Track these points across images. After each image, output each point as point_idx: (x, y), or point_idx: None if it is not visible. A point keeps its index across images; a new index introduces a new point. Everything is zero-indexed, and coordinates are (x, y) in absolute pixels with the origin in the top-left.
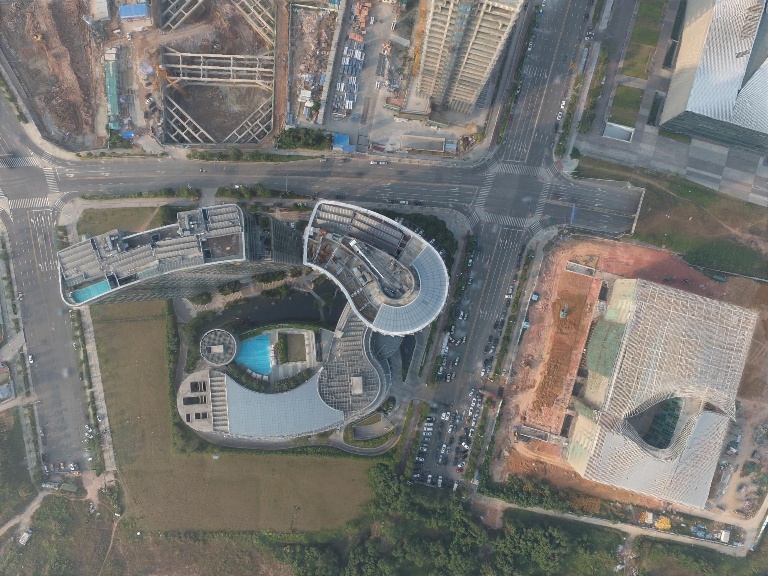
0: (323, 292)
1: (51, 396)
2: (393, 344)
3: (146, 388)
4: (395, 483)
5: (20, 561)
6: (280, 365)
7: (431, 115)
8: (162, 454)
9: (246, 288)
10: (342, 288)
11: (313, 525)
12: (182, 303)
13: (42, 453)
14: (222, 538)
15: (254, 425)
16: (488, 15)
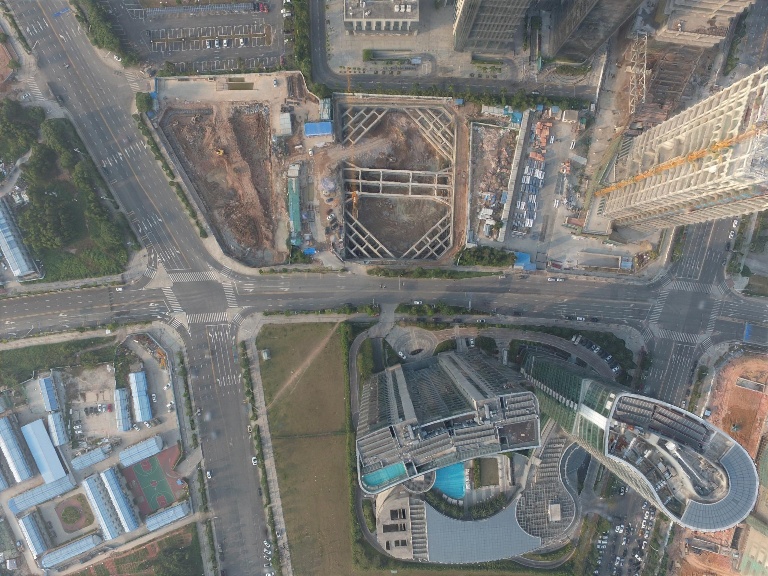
0: None
1: (229, 512)
2: (575, 462)
3: (325, 503)
4: None
5: None
6: (474, 489)
7: (611, 235)
8: (340, 569)
9: None
10: (647, 482)
11: None
12: None
13: (220, 570)
14: None
15: (453, 552)
16: (761, 198)
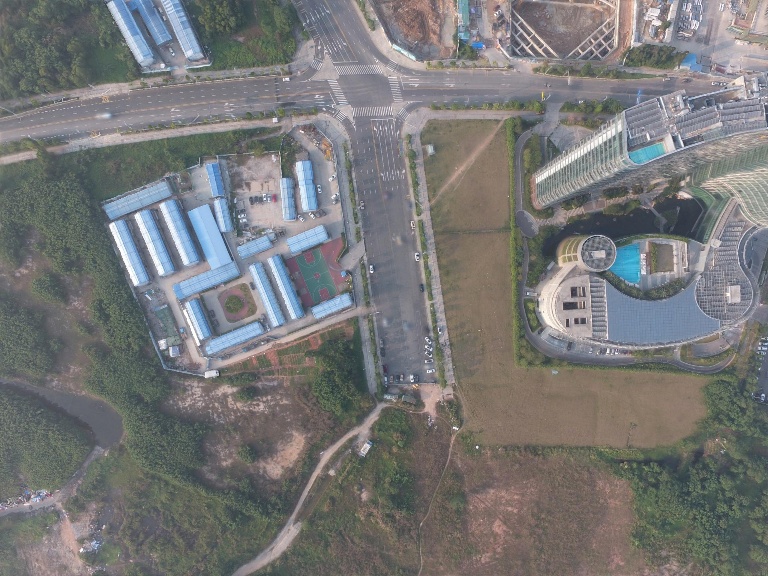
0: (665, 210)
1: (390, 307)
2: None
3: (487, 301)
4: (741, 399)
5: (358, 473)
6: (649, 275)
7: None
8: (501, 368)
9: (588, 204)
10: None
11: (649, 442)
12: (524, 217)
13: (382, 364)
14: (560, 453)
15: (632, 331)
16: None
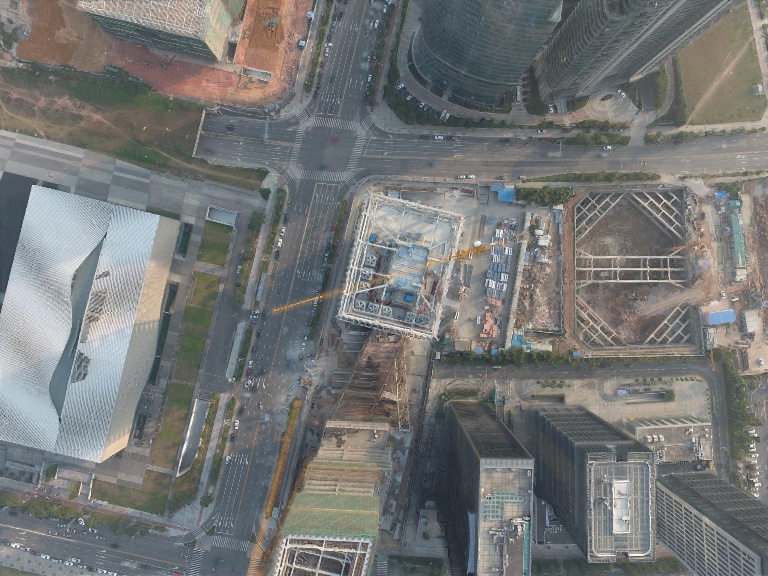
0: None
1: None
2: None
3: None
4: None
5: None
6: None
7: None
8: None
9: None
10: None
11: None
12: None
13: None
14: None
15: None
16: None
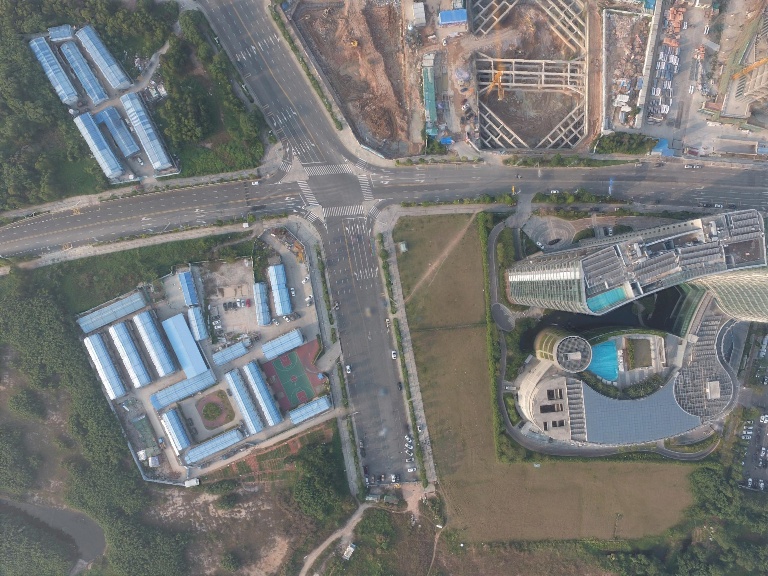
0: None
1: (369, 407)
2: None
3: (466, 397)
4: (727, 487)
5: None
6: (627, 371)
7: (749, 119)
8: (483, 463)
9: None
10: None
11: (636, 532)
12: (500, 310)
13: (363, 465)
14: (546, 547)
15: (611, 432)
16: None
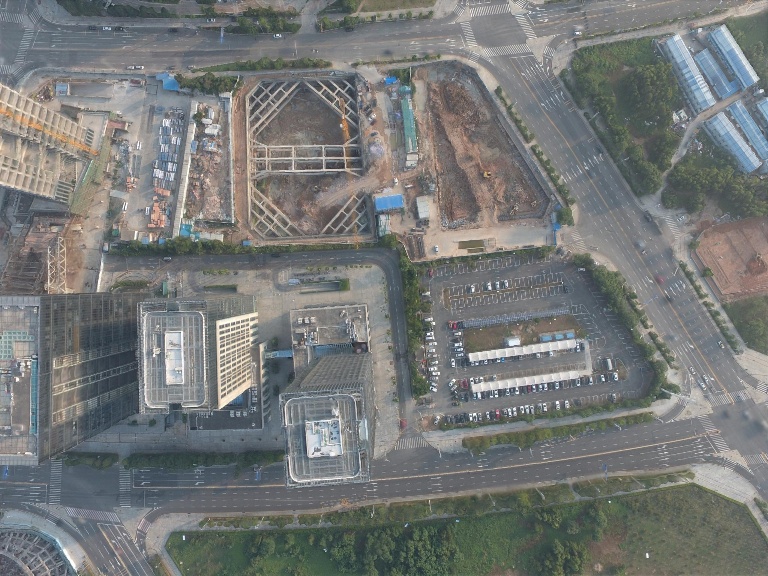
0: None
1: None
2: None
3: None
4: None
5: None
6: None
7: None
8: None
9: None
10: None
11: None
12: None
13: None
14: None
15: None
16: None
